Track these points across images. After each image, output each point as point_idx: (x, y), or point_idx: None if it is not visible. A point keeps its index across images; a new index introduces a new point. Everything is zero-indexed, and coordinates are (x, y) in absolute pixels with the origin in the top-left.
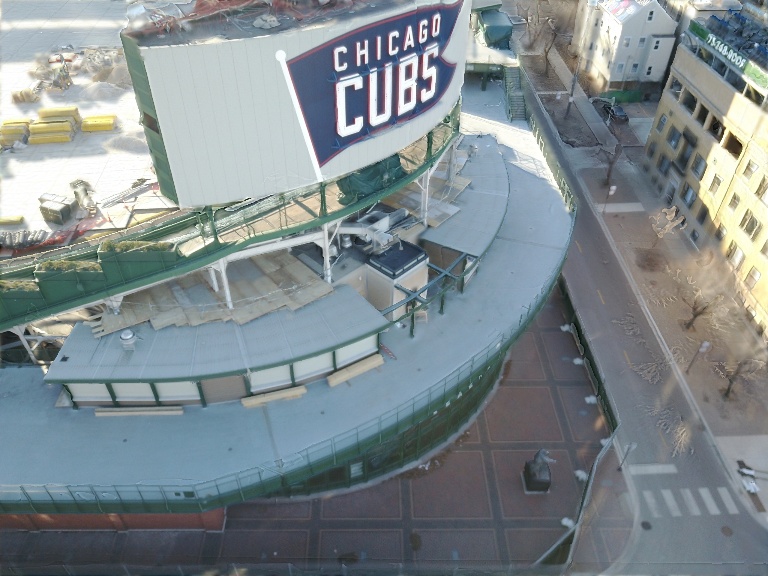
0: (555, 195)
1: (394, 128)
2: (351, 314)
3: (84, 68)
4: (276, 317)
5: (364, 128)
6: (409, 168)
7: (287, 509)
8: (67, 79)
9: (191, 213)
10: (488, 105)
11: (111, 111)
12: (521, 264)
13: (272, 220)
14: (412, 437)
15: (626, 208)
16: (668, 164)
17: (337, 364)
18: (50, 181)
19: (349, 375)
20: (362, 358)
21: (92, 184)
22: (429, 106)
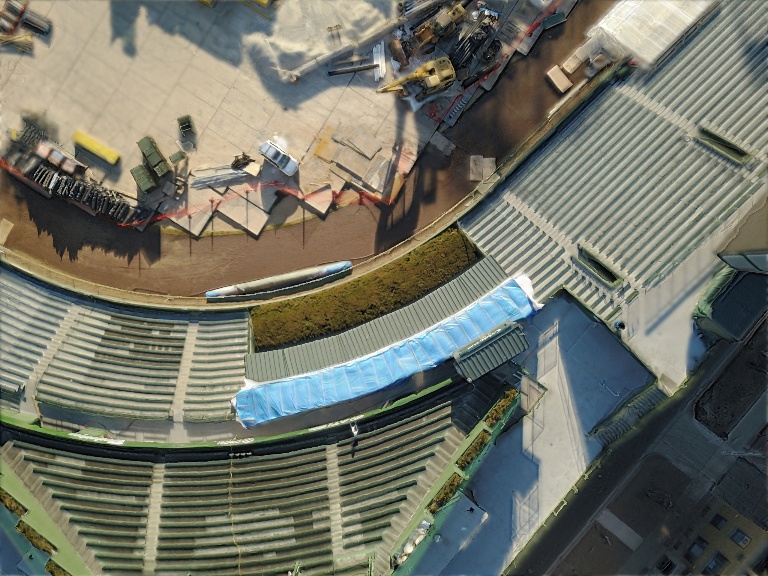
0: (494, 572)
1: None
2: None
3: None
4: None
5: None
6: None
7: None
8: None
9: (236, 309)
10: (605, 386)
11: None
12: None
13: None
14: None
15: (623, 536)
16: (694, 560)
17: None
18: (164, 92)
19: None
20: None
21: (199, 130)
22: None
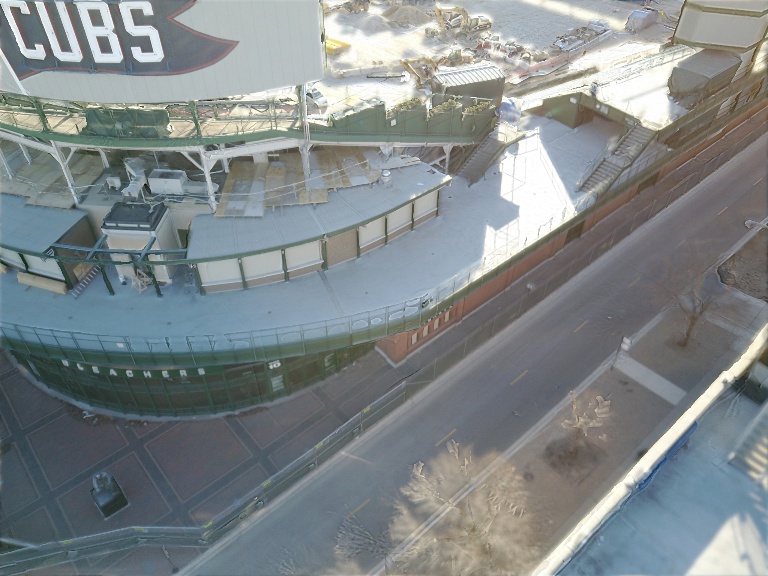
0: None
1: (86, 72)
2: (42, 230)
3: (389, 1)
4: (16, 201)
5: (49, 58)
6: (178, 136)
7: (0, 360)
8: (363, 5)
9: None
10: None
11: (356, 41)
12: (290, 312)
13: (32, 118)
14: (72, 377)
15: (654, 385)
16: None
17: (31, 267)
18: None
19: (34, 282)
20: (53, 277)
21: None
22: (167, 72)
